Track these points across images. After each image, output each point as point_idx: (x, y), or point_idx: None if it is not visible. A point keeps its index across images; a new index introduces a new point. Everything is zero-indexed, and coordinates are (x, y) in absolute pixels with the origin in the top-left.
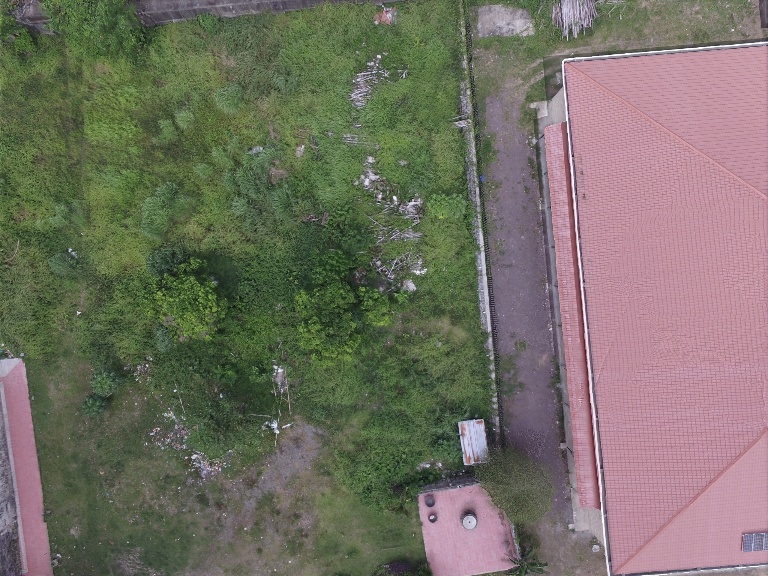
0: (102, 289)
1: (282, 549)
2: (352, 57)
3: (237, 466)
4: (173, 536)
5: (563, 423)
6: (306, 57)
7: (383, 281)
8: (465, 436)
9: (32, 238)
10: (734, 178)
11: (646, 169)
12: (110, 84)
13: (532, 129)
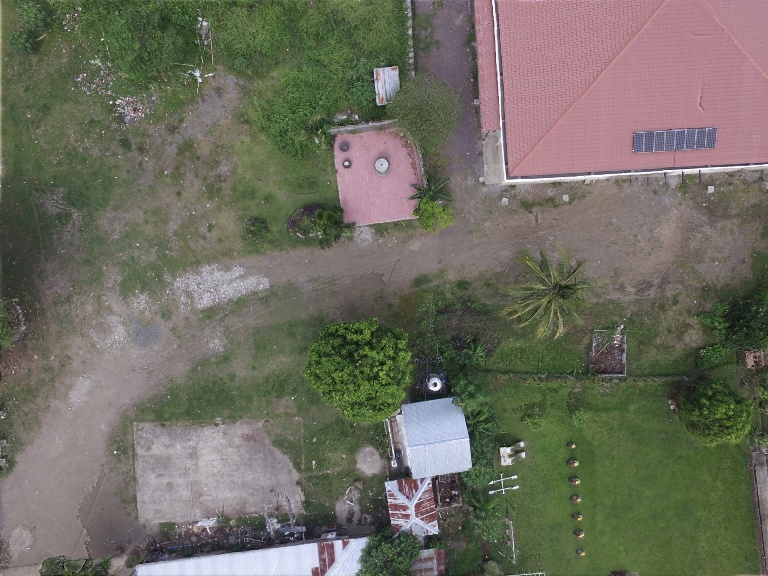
0: None
1: (201, 193)
2: None
3: (160, 112)
4: (96, 177)
5: (477, 81)
6: None
7: None
8: (379, 80)
9: None
10: None
11: None
12: None
13: None
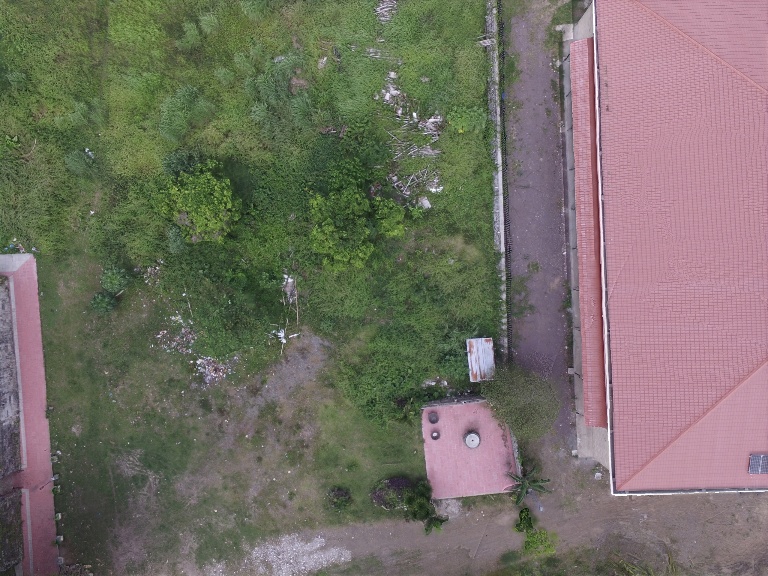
0: (117, 189)
1: (282, 459)
2: None
3: (242, 373)
4: (174, 439)
5: (572, 348)
6: None
7: (398, 197)
8: (473, 353)
9: (50, 135)
10: (761, 91)
11: (672, 81)
12: None
13: (556, 52)
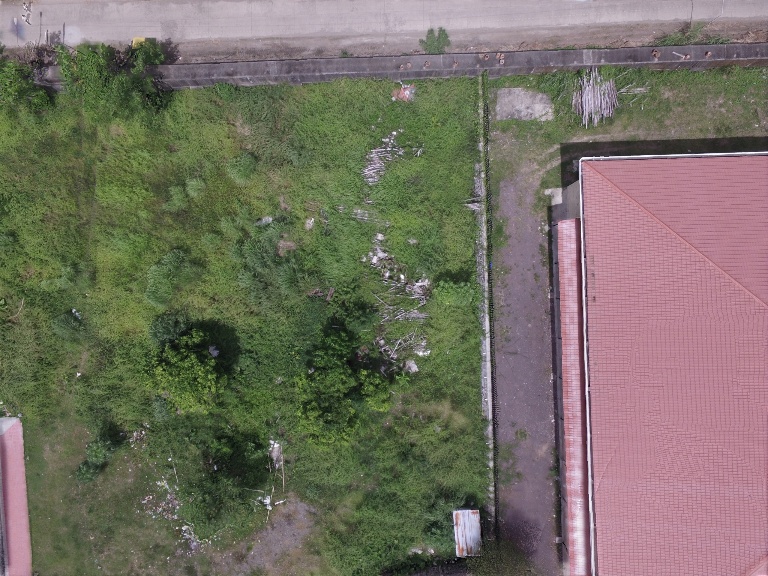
0: (103, 352)
1: None
2: (367, 133)
3: (227, 540)
4: None
5: (560, 517)
6: (321, 130)
7: (385, 361)
8: (459, 526)
9: (37, 296)
10: (750, 296)
11: (659, 278)
12: (124, 146)
13: (545, 216)
